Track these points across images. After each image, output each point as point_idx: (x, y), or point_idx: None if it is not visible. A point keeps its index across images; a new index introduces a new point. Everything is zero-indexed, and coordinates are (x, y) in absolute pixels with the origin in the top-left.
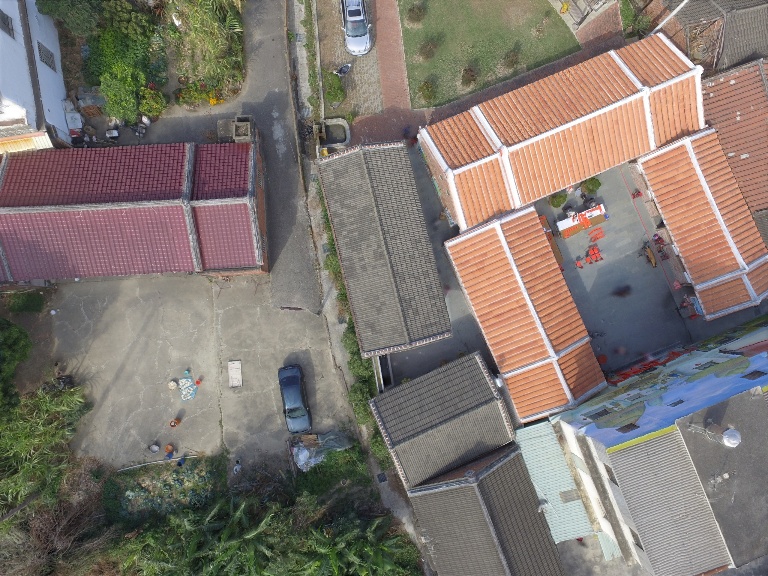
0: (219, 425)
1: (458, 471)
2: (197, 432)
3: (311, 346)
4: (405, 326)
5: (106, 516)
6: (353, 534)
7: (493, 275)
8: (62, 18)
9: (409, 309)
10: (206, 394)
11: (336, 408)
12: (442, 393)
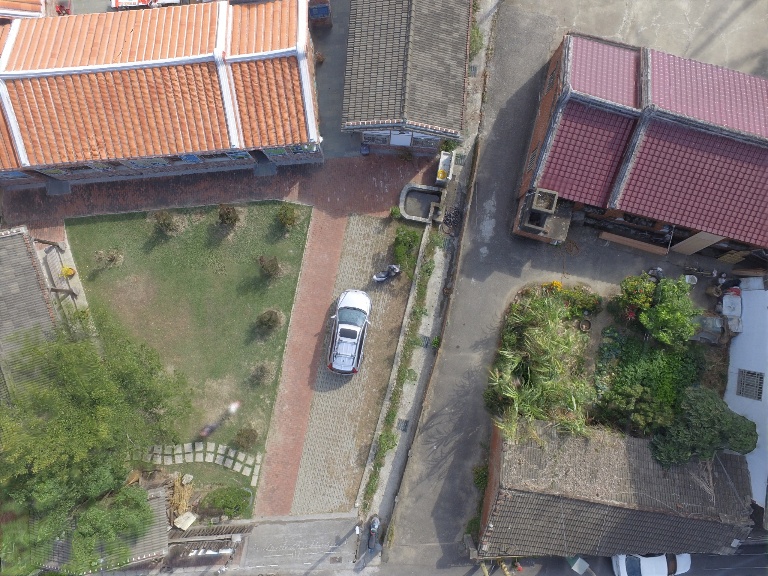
0: None
1: None
2: None
3: None
4: None
5: None
6: None
7: None
8: (730, 410)
9: None
10: None
11: None
12: None
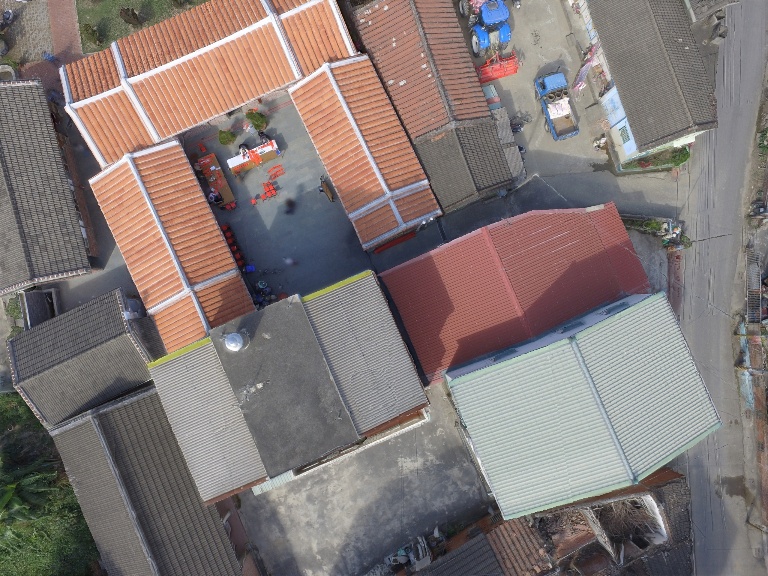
0: None
1: None
2: None
3: None
4: (26, 262)
5: None
6: None
7: (131, 210)
8: None
9: (35, 245)
10: None
11: None
12: (77, 330)
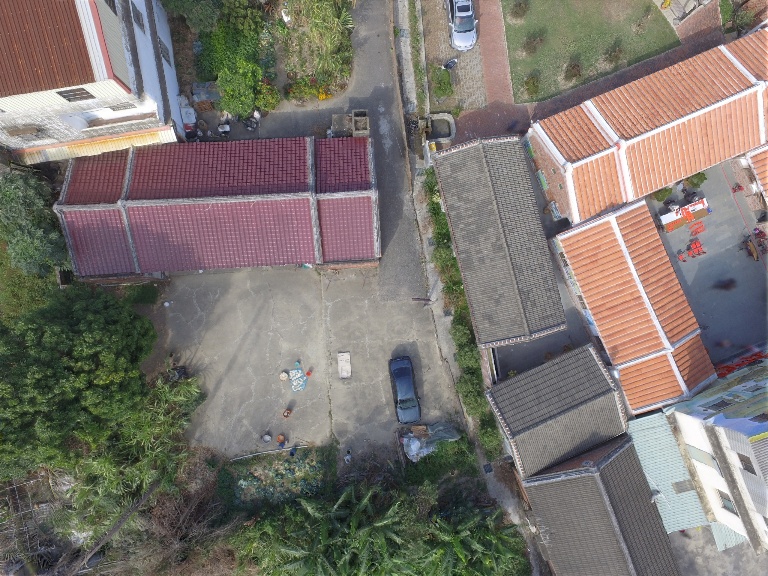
0: (328, 416)
1: (573, 461)
2: (307, 422)
3: (418, 338)
4: (525, 318)
5: (221, 504)
6: (474, 523)
7: (607, 268)
8: (186, 14)
9: (527, 301)
10: (316, 385)
11: (442, 399)
12: (558, 384)
